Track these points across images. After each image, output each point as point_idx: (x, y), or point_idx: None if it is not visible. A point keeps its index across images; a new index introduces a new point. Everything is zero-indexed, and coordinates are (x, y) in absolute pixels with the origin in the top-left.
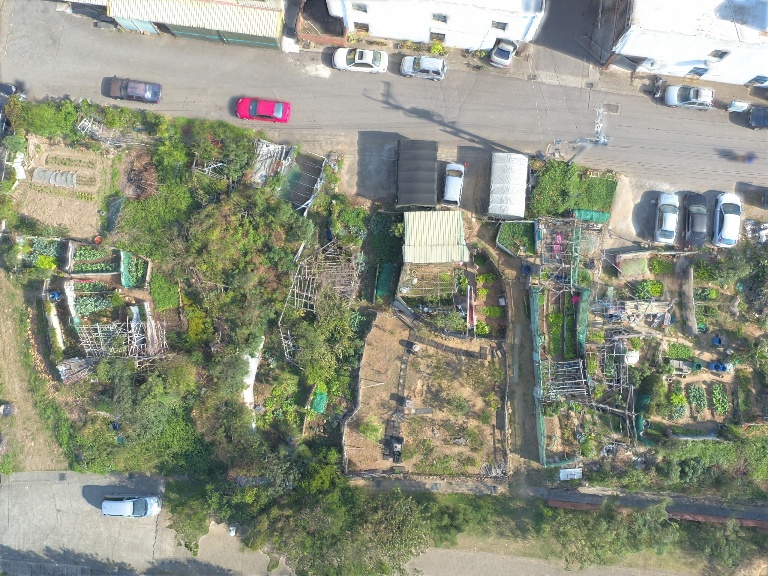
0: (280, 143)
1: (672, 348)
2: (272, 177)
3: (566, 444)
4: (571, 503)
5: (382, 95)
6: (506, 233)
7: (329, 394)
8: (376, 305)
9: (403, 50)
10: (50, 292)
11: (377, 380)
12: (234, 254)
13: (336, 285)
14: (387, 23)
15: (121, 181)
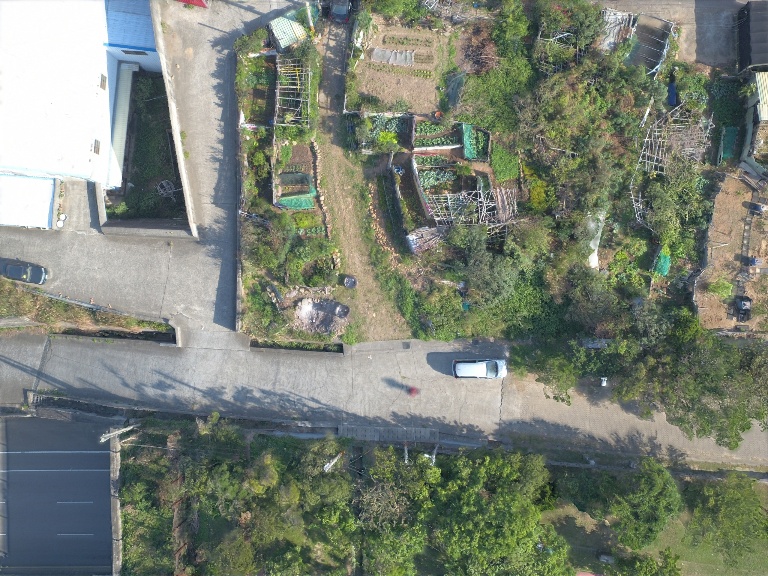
0: None
1: None
2: (623, 43)
3: None
4: None
5: None
6: None
7: (672, 257)
8: (720, 168)
9: None
10: (395, 166)
11: (721, 241)
12: (583, 121)
13: (685, 147)
14: None
15: (459, 58)
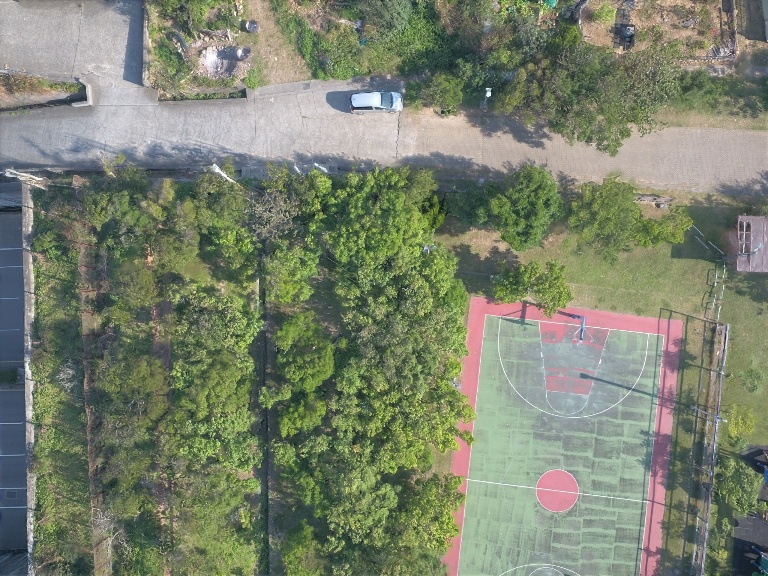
0: None
1: None
2: None
3: None
4: None
5: None
6: None
7: None
8: None
9: None
10: None
11: None
12: None
13: None
14: None
15: None
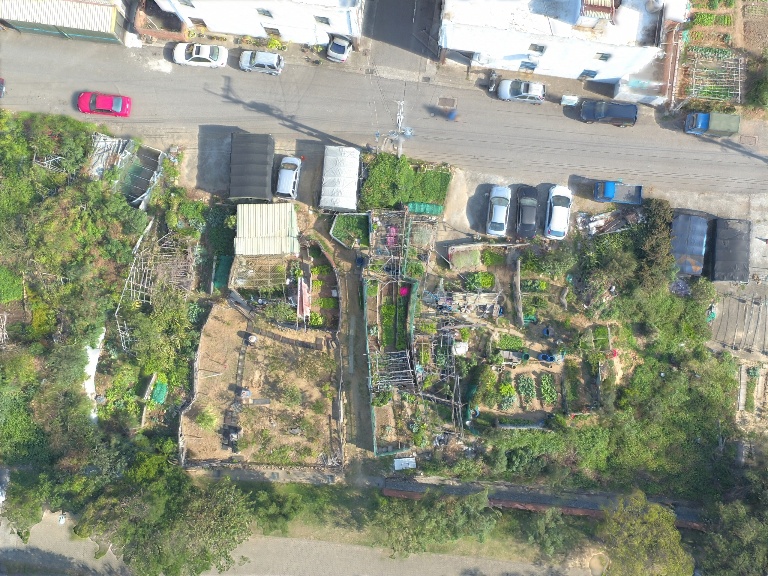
0: (122, 137)
1: (503, 339)
2: (108, 170)
3: (400, 434)
4: (405, 492)
5: (222, 89)
6: (340, 225)
7: (169, 384)
8: (214, 297)
9: (243, 45)
10: None
11: (216, 371)
12: (73, 246)
13: (172, 277)
14: (219, 18)
15: None
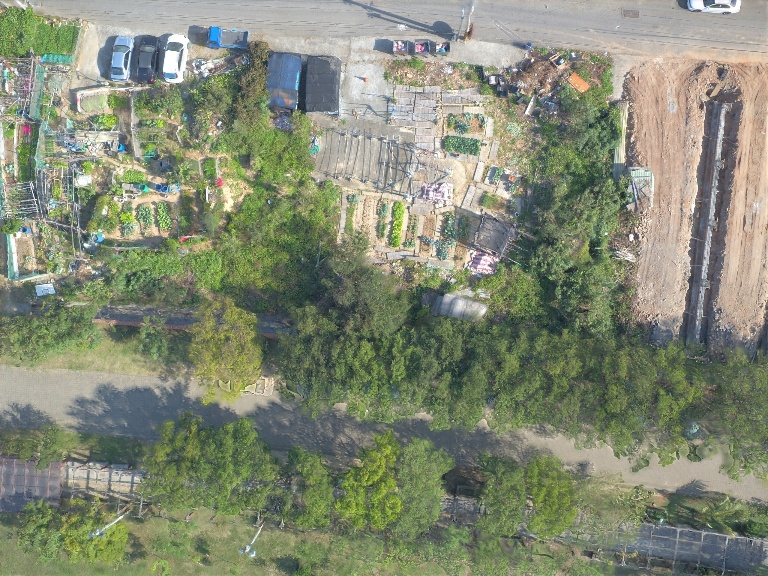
0: None
1: (127, 173)
2: None
3: (39, 262)
4: None
5: None
6: None
7: None
8: None
9: None
10: None
11: None
12: None
13: None
14: None
15: None
